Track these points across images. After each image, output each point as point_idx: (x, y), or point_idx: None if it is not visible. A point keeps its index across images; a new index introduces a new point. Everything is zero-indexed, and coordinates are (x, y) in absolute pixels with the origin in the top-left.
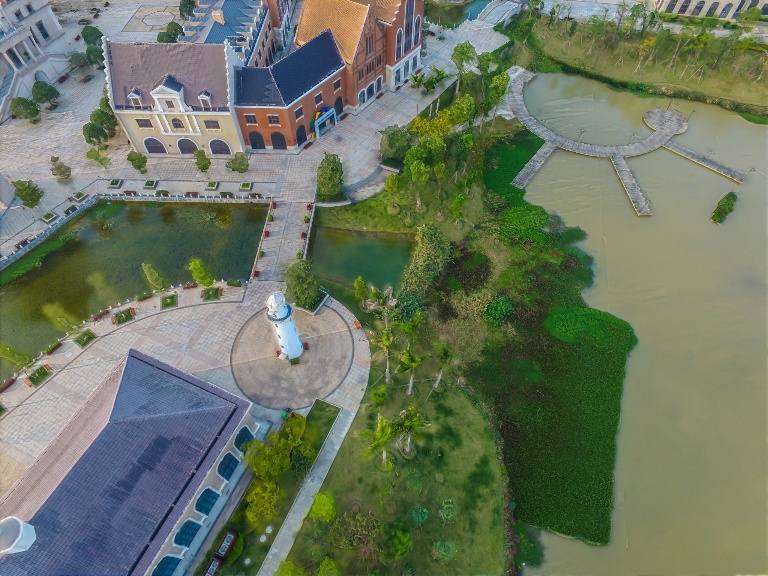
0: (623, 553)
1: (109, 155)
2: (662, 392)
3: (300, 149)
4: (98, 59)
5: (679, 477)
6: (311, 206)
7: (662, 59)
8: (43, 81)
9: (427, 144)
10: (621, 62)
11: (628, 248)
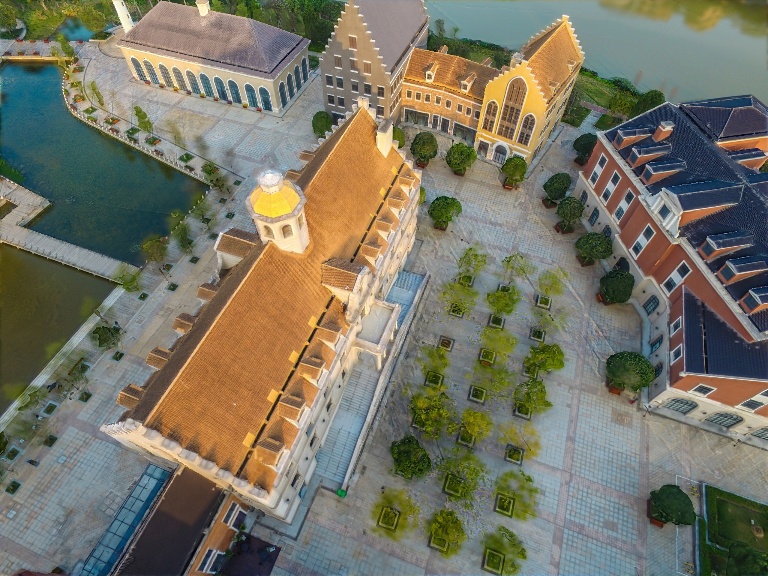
0: None
1: None
2: None
3: None
4: None
5: None
6: None
7: None
8: None
9: None
10: None
11: None
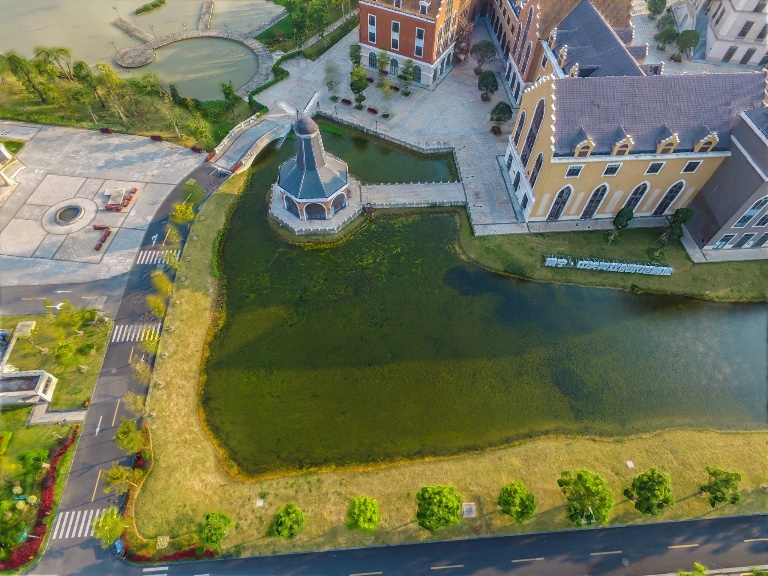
0: None
1: None
2: None
3: None
4: None
5: None
6: None
7: None
8: None
9: None
10: None
11: None
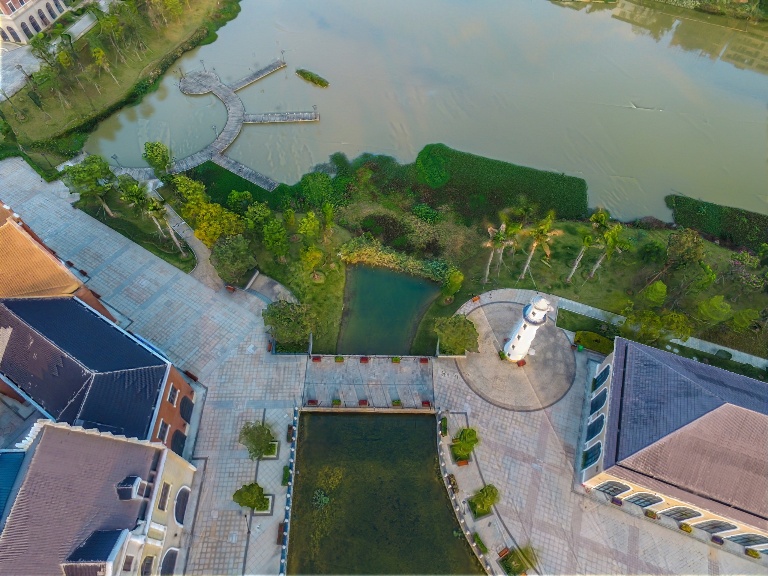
0: (586, 175)
1: None
2: (479, 140)
3: (196, 387)
4: None
5: (534, 145)
6: None
7: (114, 60)
8: None
9: (260, 218)
10: (99, 87)
11: (352, 133)
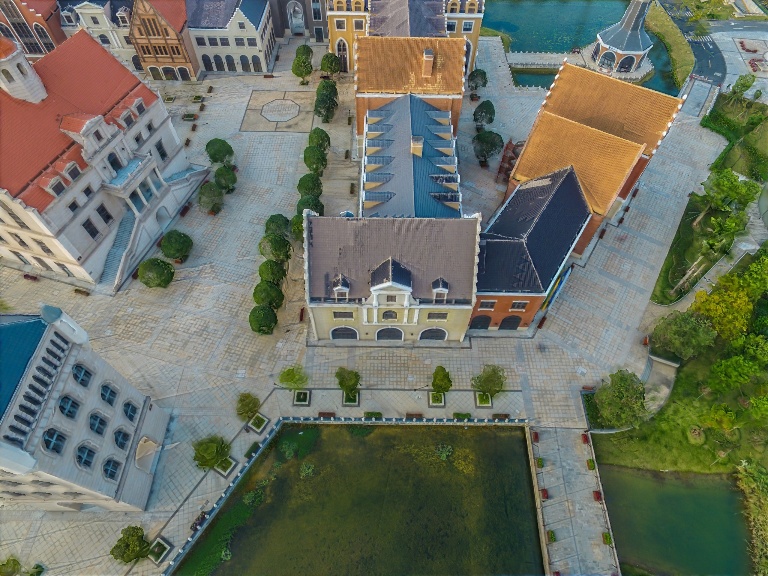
0: None
1: (279, 343)
2: None
3: (533, 328)
4: (230, 183)
5: None
6: (587, 436)
7: None
8: (175, 230)
9: (752, 351)
10: None
11: None
